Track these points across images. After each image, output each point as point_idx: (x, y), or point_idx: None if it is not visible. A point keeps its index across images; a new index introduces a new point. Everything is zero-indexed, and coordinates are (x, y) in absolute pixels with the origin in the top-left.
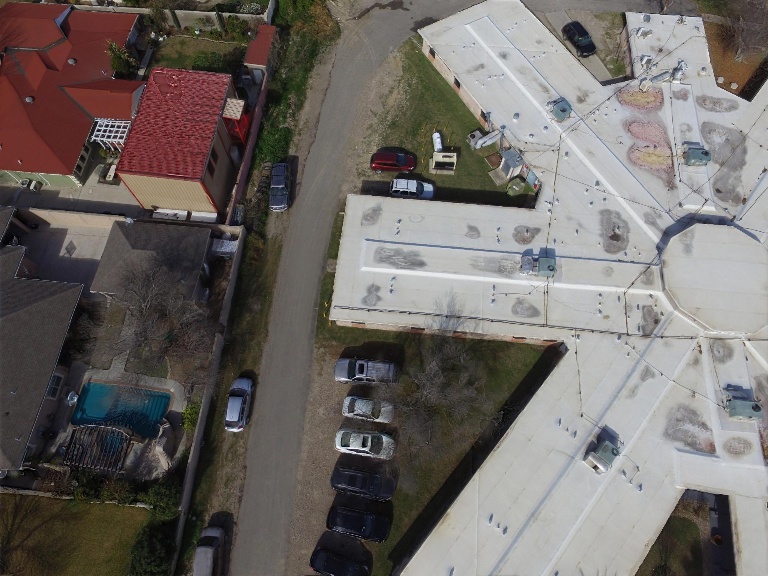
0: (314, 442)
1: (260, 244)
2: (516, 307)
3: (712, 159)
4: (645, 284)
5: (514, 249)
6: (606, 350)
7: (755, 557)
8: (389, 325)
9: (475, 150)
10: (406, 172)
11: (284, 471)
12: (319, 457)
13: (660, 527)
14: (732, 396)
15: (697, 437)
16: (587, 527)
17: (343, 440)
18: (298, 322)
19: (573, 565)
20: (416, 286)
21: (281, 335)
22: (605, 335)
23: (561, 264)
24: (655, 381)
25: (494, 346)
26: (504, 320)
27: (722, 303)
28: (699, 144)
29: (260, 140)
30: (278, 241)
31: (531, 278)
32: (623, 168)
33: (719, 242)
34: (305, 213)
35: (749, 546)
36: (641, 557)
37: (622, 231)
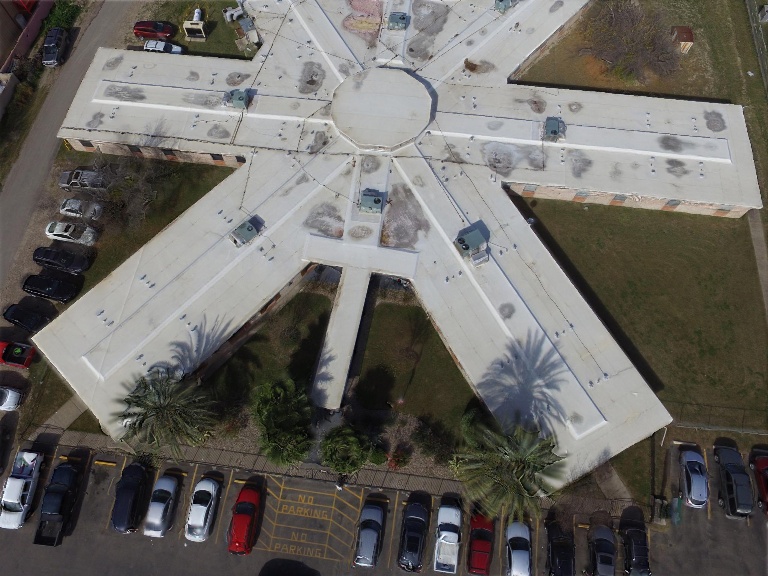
0: (34, 234)
1: (29, 91)
2: (212, 131)
3: (414, 26)
4: (322, 115)
5: (223, 89)
6: (276, 163)
7: (348, 309)
8: (112, 147)
9: (228, 23)
10: (164, 38)
11: (5, 254)
12: (35, 244)
13: (279, 287)
14: (363, 194)
15: (330, 226)
16: (220, 285)
17: (51, 228)
18: (45, 148)
19: (199, 311)
20: (134, 114)
21: (29, 157)
22: (278, 152)
23: (258, 100)
24: (307, 184)
25: (201, 168)
26: (198, 139)
27: (371, 124)
28: (406, 14)
29: (51, 14)
30: (46, 90)
31: (229, 109)
32: (334, 31)
33: (385, 81)
34: (73, 69)
35: (346, 301)
36: (256, 307)
37: (318, 78)
